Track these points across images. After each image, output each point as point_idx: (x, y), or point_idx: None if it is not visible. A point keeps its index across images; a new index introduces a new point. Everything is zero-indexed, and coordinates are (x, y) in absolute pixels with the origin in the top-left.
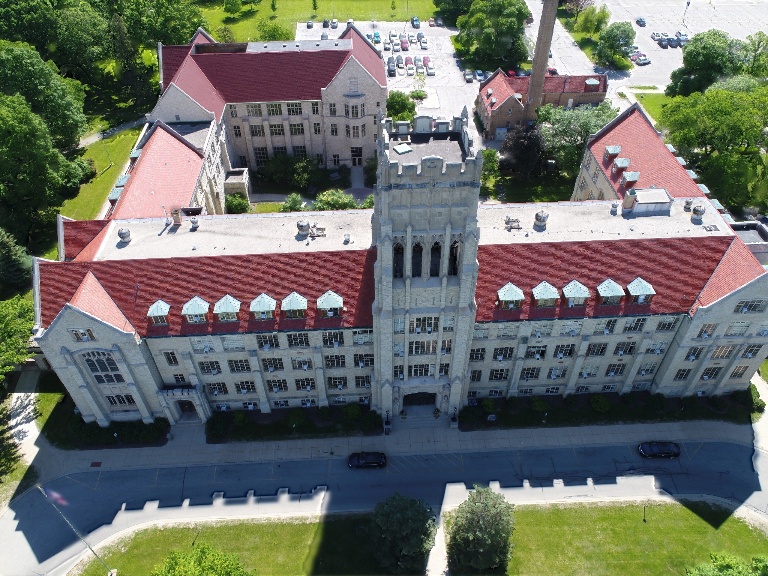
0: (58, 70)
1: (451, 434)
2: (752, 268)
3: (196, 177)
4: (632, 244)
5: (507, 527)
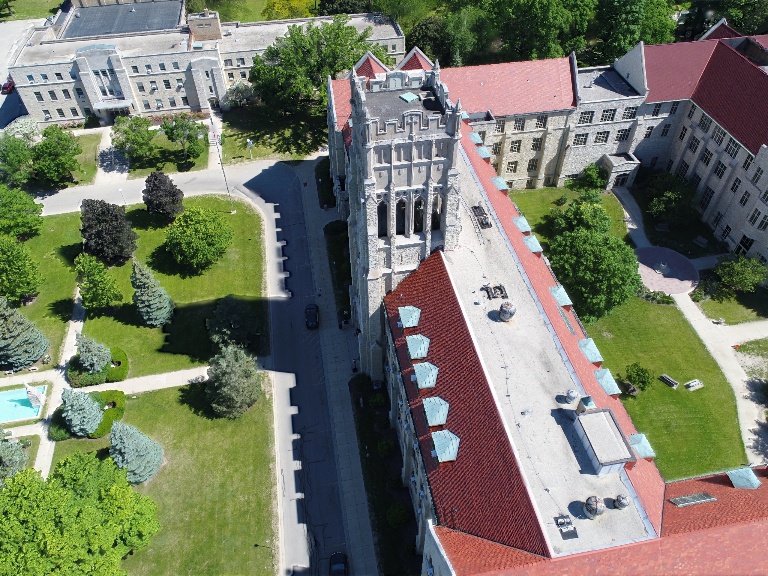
0: (654, 2)
1: (344, 374)
2: (476, 567)
3: (542, 109)
4: (491, 410)
5: (223, 386)
